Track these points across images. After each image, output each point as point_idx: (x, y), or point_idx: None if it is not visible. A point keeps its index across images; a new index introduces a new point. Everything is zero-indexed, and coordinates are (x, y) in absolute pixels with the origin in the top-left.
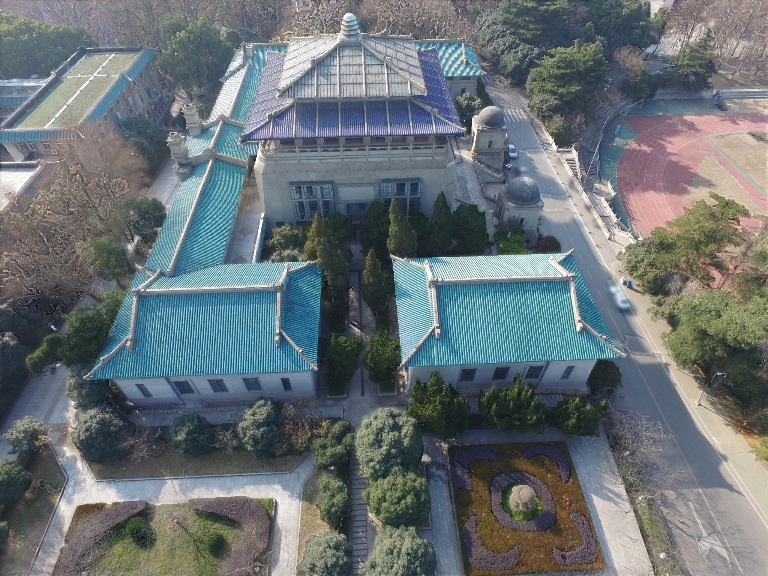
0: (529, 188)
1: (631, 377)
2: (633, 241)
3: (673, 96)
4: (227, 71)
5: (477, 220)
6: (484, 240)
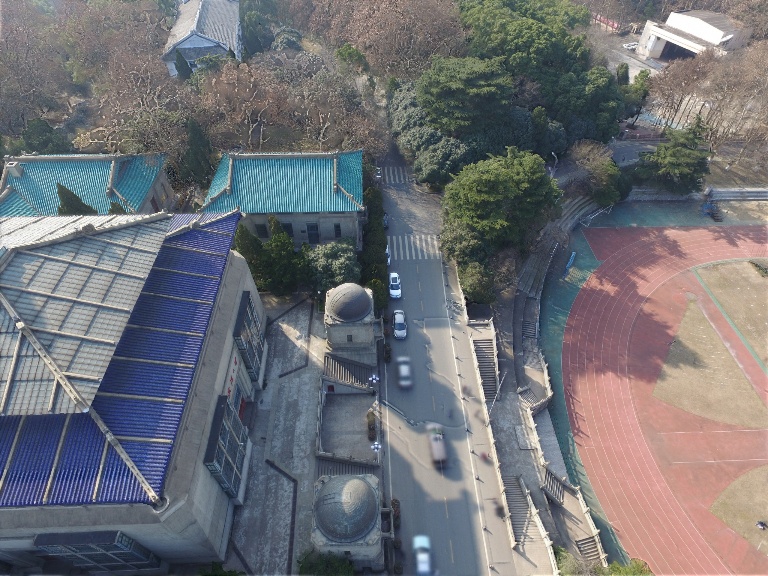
0: (348, 518)
1: None
2: (552, 561)
3: (652, 196)
4: None
5: None
6: None
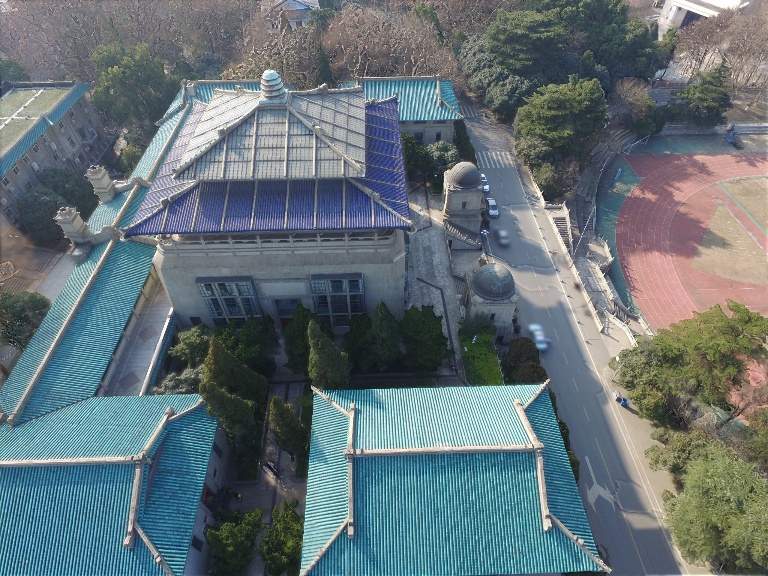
0: (500, 281)
1: (622, 551)
2: (631, 337)
3: (682, 131)
4: (166, 112)
5: (430, 330)
6: (439, 354)
